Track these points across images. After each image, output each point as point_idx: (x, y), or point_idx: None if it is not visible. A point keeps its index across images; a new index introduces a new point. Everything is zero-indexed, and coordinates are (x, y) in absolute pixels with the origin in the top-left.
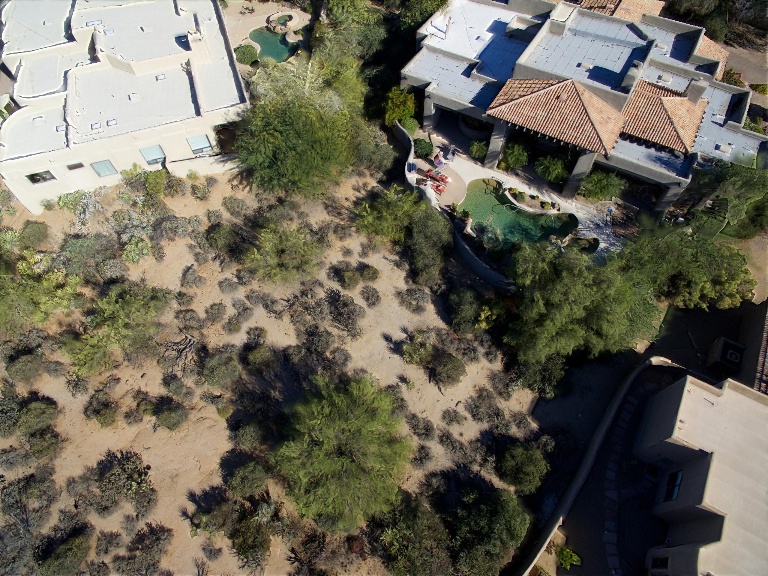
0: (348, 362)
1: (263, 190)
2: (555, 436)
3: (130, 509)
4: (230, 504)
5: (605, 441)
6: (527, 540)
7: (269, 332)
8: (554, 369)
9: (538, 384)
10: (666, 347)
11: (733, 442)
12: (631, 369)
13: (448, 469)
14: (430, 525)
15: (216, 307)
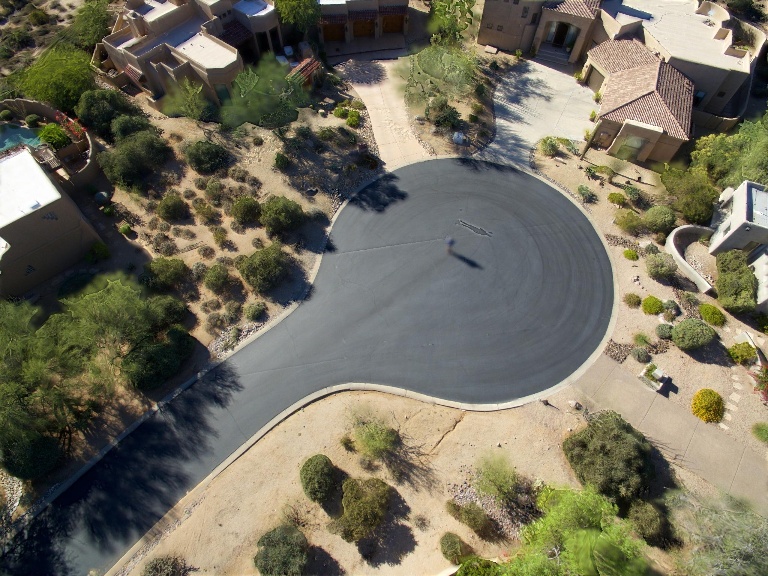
0: None
1: None
2: None
3: None
4: None
5: (736, 96)
6: (757, 63)
7: None
8: None
9: None
10: None
11: (712, 59)
12: (734, 128)
13: None
14: None
15: None
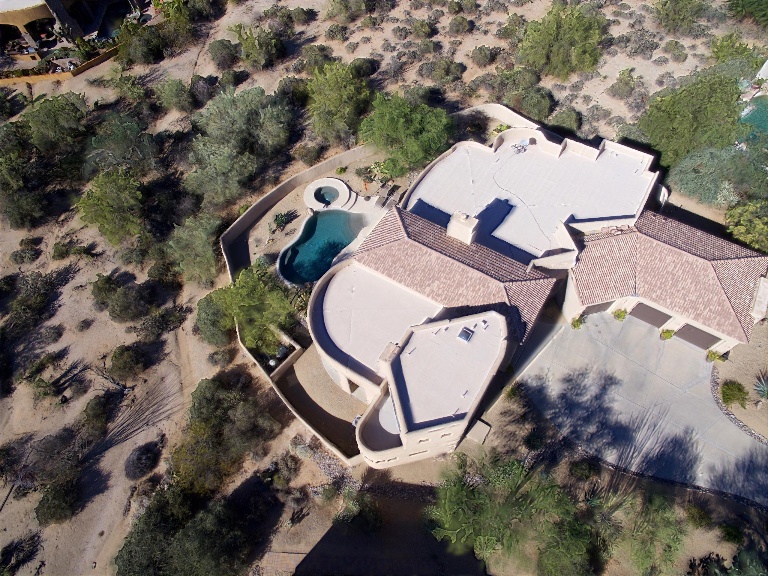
0: (610, 55)
1: (729, 6)
2: (588, 140)
3: (513, 0)
4: (522, 21)
5: None
6: None
7: (619, 26)
8: (636, 134)
9: (622, 132)
10: (681, 218)
11: (610, 176)
12: None
13: (555, 98)
14: (526, 79)
15: (628, 5)
